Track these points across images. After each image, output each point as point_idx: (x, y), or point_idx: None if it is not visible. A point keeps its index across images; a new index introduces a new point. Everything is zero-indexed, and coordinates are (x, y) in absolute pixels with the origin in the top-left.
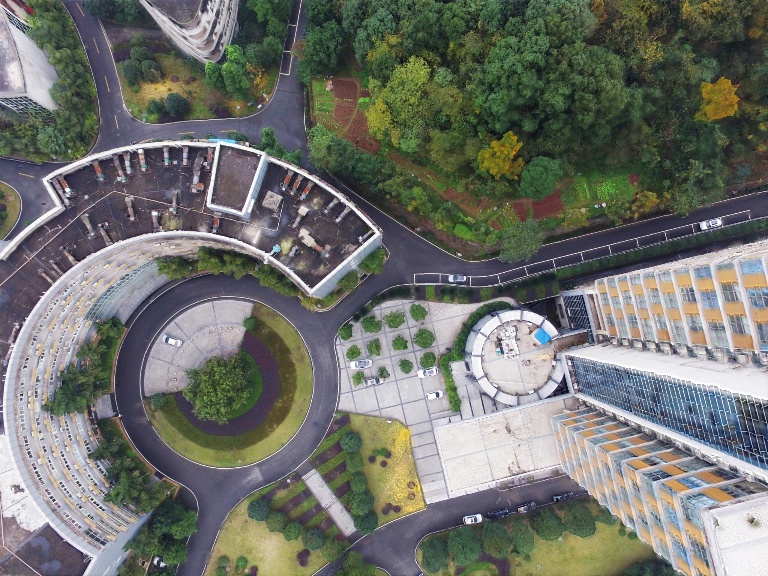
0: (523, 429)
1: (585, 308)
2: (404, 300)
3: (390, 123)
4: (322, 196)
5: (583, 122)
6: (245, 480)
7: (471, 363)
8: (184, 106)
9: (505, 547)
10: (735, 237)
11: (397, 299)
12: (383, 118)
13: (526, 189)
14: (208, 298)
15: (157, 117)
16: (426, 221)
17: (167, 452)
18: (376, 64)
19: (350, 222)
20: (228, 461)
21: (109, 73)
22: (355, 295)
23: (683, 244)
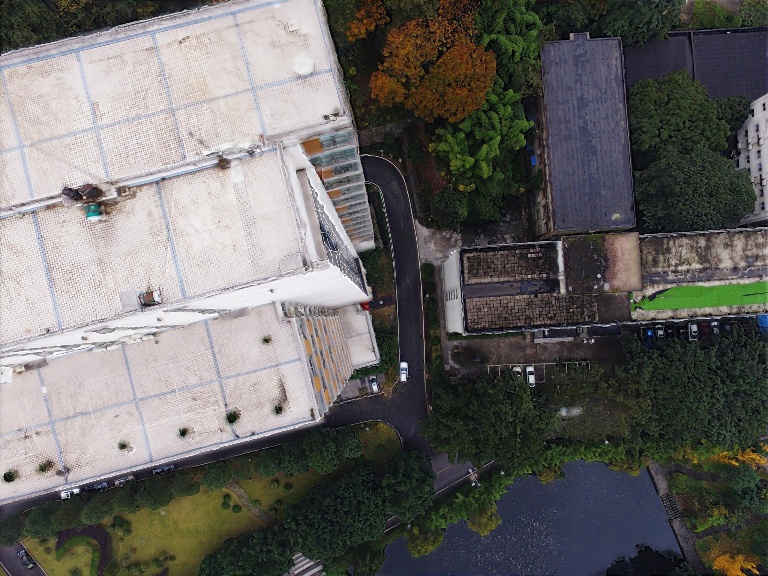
0: None
1: None
2: None
3: None
4: None
5: None
6: None
7: None
8: None
9: (62, 519)
10: None
11: None
12: None
13: None
14: None
15: None
16: None
17: None
18: None
19: None
20: None
21: None
22: None
23: None
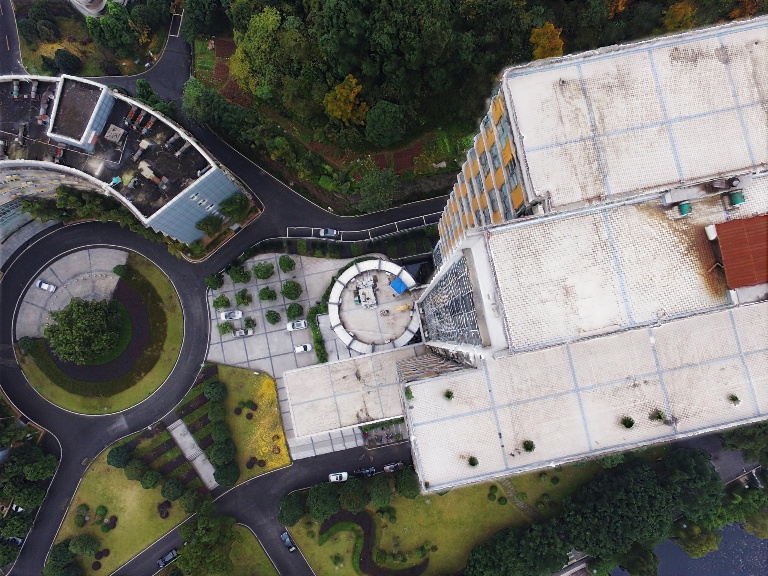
0: (373, 376)
1: (441, 258)
2: (277, 253)
3: (250, 72)
4: (165, 132)
5: (411, 62)
6: (110, 428)
7: (329, 311)
8: (73, 62)
9: (357, 500)
10: None
11: (270, 252)
12: (242, 67)
13: (370, 133)
14: (84, 245)
15: (50, 74)
16: (296, 174)
17: (34, 397)
18: (234, 14)
19: (191, 157)
20: (94, 408)
21: (10, 33)
22: (229, 247)
23: None
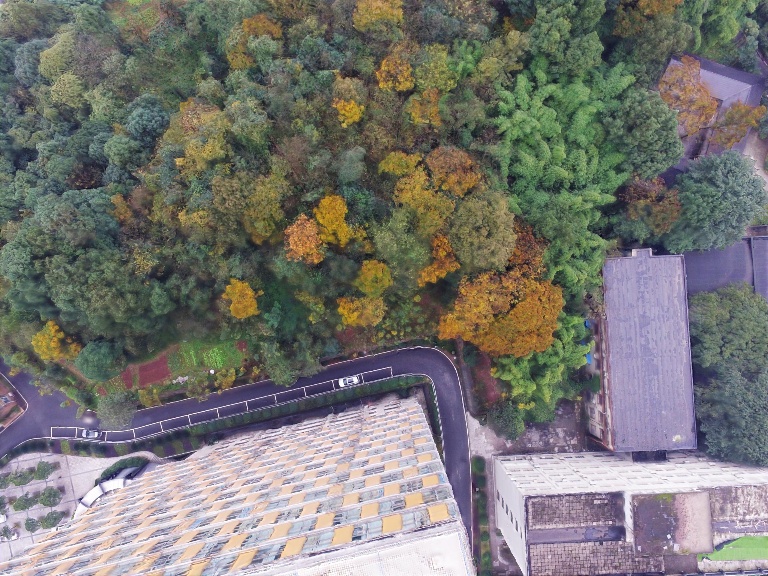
0: None
1: None
2: (42, 453)
3: None
4: None
5: None
6: None
7: None
8: None
9: None
10: (378, 393)
11: (34, 452)
12: None
13: None
14: None
15: None
16: None
17: None
18: None
19: None
20: None
21: None
22: None
23: (320, 402)
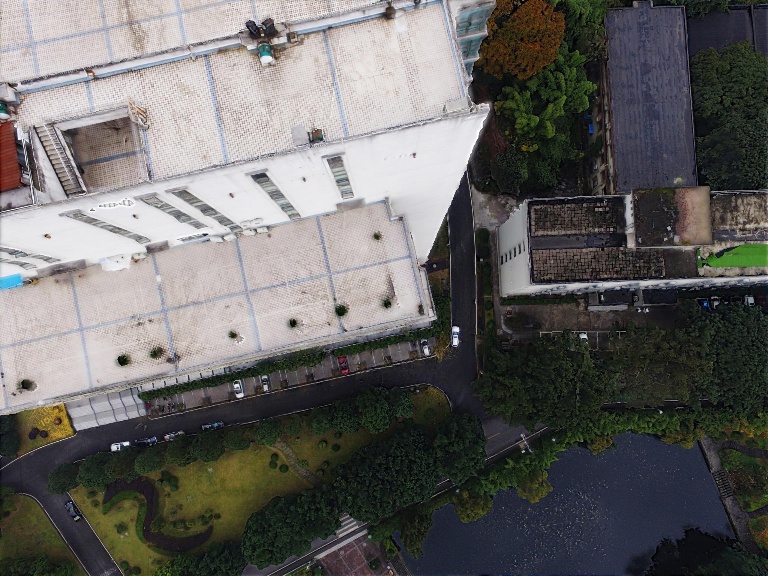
0: None
1: None
2: None
3: None
4: None
5: None
6: None
7: None
8: None
9: (116, 466)
10: None
11: None
12: None
13: None
14: None
15: None
16: None
17: None
18: None
19: None
20: None
21: None
22: None
23: None
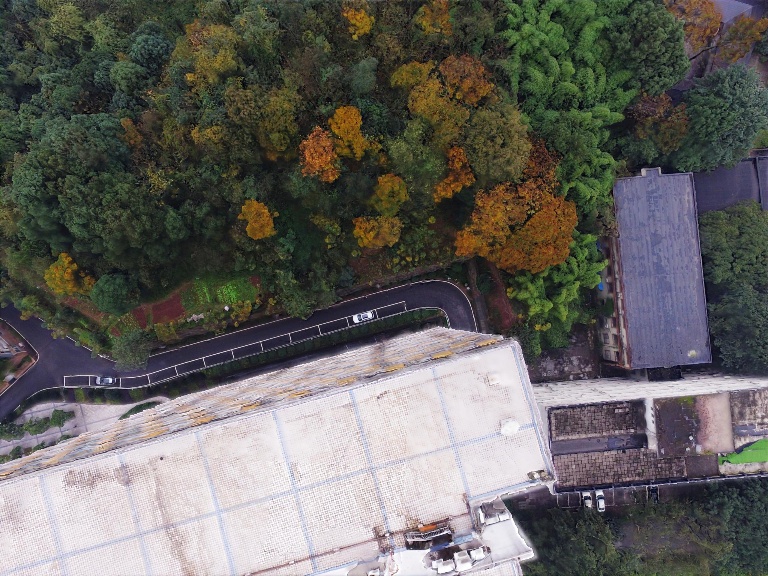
0: None
1: None
2: (56, 403)
3: None
4: None
5: None
6: None
7: None
8: None
9: None
10: (392, 329)
11: (48, 402)
12: None
13: None
14: None
15: None
16: None
17: None
18: None
19: None
20: None
21: None
22: (5, 399)
23: (335, 339)
